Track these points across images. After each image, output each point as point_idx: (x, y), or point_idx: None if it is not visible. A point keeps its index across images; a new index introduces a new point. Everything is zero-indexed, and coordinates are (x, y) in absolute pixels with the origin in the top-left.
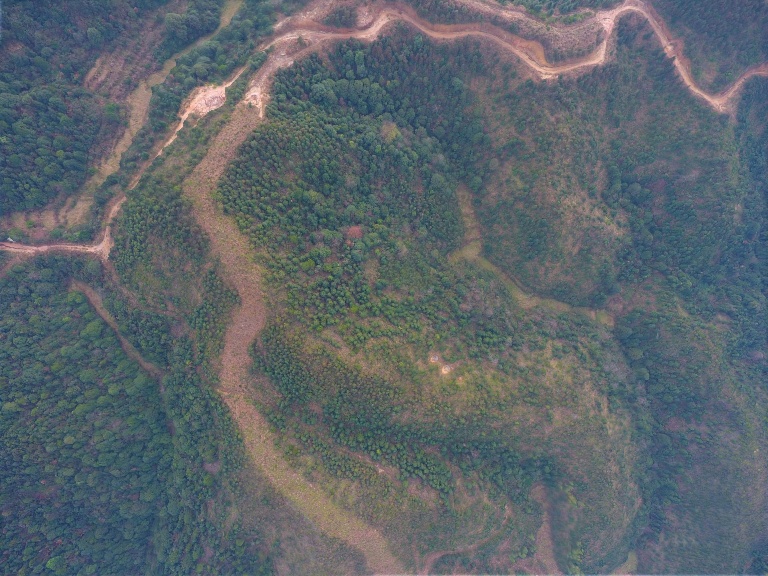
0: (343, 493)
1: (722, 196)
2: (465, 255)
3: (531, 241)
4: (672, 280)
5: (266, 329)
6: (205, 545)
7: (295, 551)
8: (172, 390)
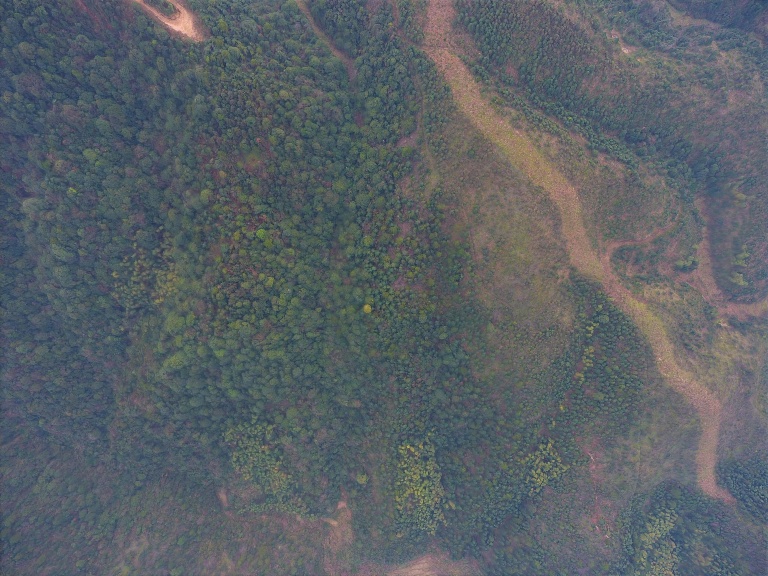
0: (547, 142)
1: None
2: None
3: None
4: None
5: None
6: (402, 221)
7: (498, 209)
8: (368, 66)
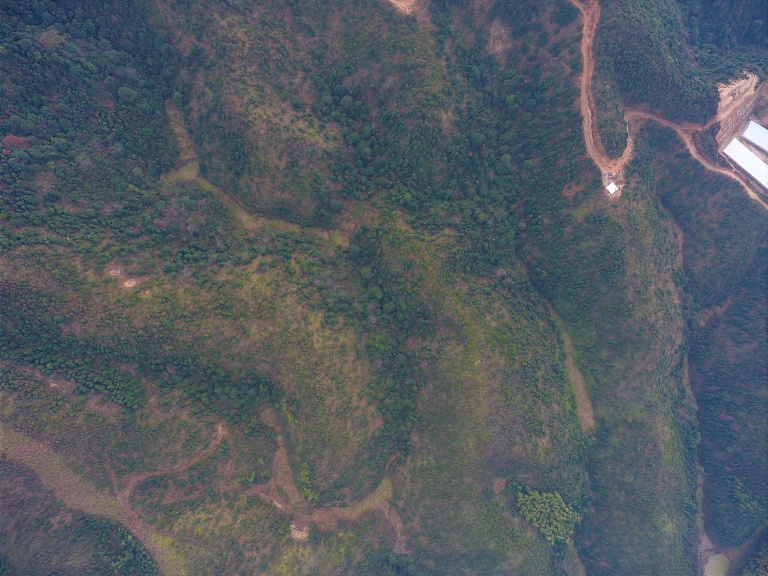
0: None
1: (422, 102)
2: (182, 176)
3: (232, 155)
4: (392, 194)
5: None
6: None
7: None
8: None
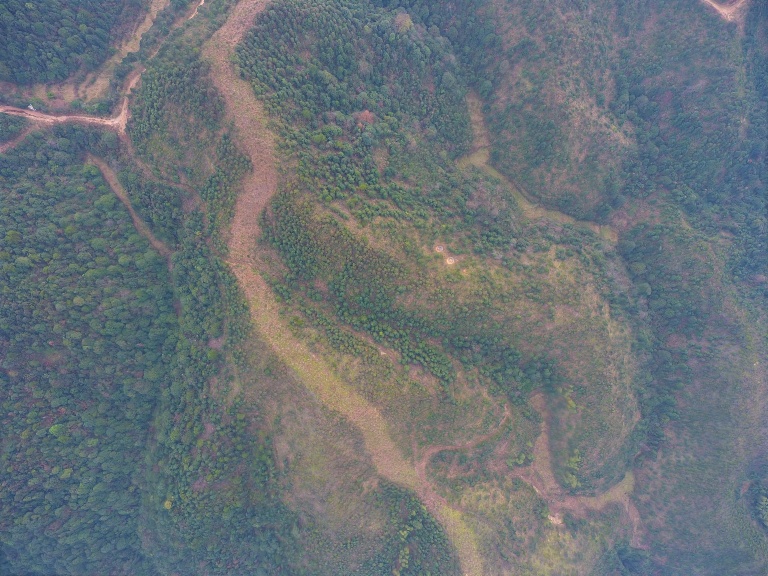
0: (345, 366)
1: (728, 106)
2: (473, 162)
3: (538, 145)
4: (676, 193)
5: (276, 195)
6: (206, 422)
7: (295, 425)
8: (181, 265)
